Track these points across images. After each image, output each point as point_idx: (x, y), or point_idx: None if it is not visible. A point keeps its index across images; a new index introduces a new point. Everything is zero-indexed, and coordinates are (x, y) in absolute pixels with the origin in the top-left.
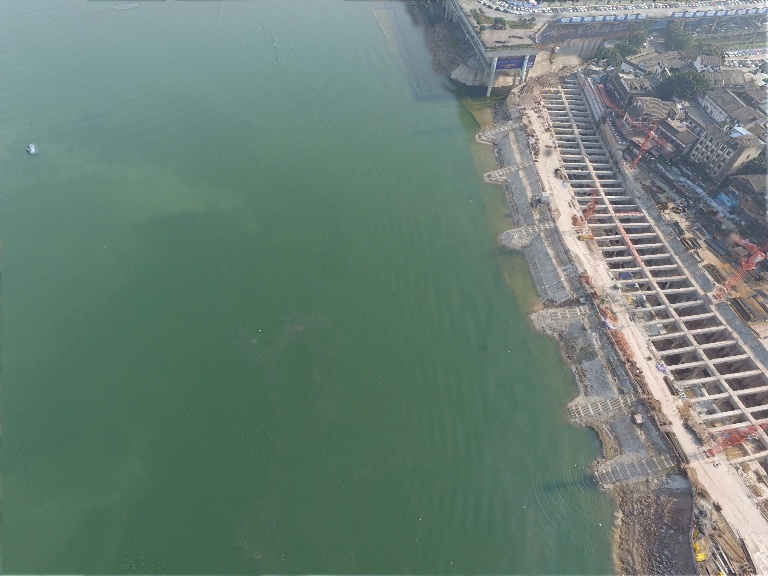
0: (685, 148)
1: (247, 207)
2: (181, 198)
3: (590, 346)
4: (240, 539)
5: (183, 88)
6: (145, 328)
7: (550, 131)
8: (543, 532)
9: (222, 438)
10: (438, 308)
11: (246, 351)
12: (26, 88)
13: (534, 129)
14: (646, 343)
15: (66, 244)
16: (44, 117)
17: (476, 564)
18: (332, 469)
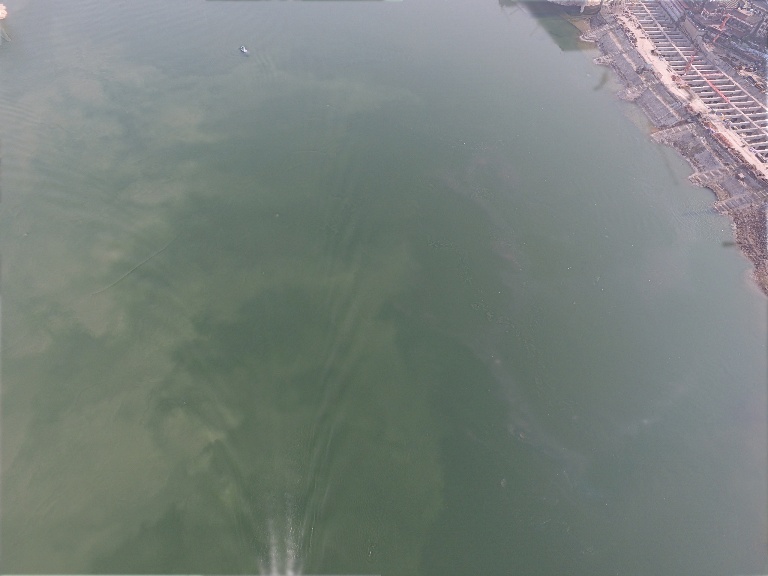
0: (753, 28)
1: (420, 82)
2: (370, 77)
3: (699, 145)
4: (495, 236)
5: (334, 14)
6: (384, 143)
7: (641, 28)
8: (687, 233)
9: (463, 193)
10: (583, 132)
11: (458, 155)
12: (218, 12)
13: (628, 27)
14: (740, 139)
15: (299, 104)
16: (244, 29)
17: (648, 245)
18: (541, 206)
